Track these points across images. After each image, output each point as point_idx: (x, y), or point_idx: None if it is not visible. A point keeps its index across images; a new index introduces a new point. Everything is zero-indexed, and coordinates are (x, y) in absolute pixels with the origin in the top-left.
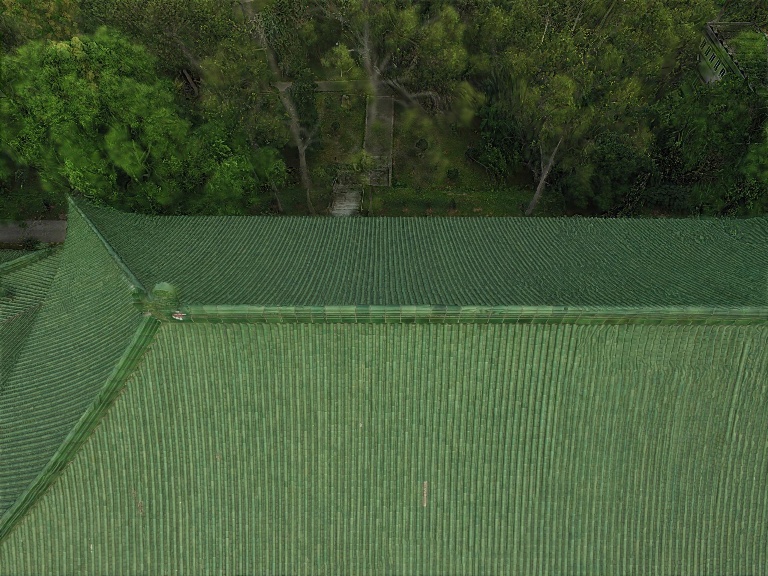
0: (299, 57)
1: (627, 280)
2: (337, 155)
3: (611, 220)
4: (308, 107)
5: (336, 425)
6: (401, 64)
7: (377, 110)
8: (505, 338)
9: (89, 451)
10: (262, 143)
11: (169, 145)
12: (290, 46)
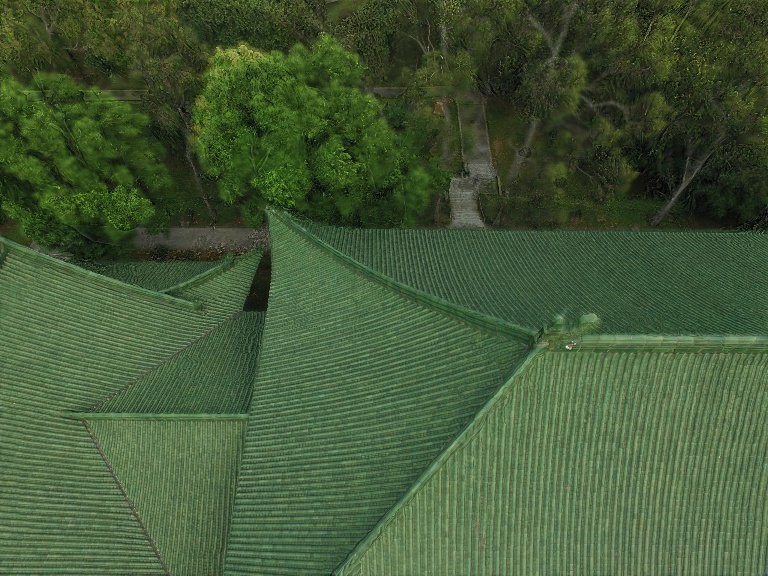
0: (387, 63)
1: None
2: (438, 162)
3: None
4: (420, 114)
5: (694, 456)
6: (508, 72)
7: (469, 117)
8: None
9: (437, 481)
10: (381, 151)
11: (286, 152)
12: (381, 52)
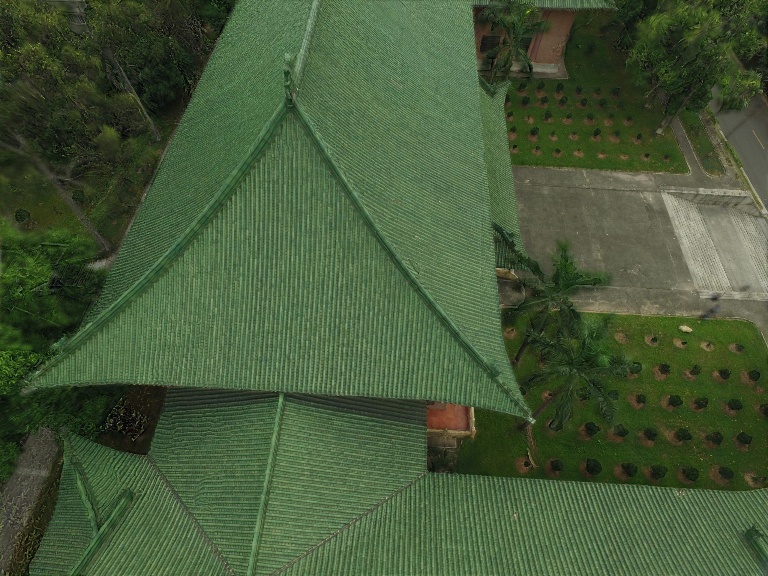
0: None
1: (288, 1)
2: None
3: (225, 30)
4: None
5: None
6: None
7: None
8: (331, 0)
9: None
10: None
11: None
12: None
